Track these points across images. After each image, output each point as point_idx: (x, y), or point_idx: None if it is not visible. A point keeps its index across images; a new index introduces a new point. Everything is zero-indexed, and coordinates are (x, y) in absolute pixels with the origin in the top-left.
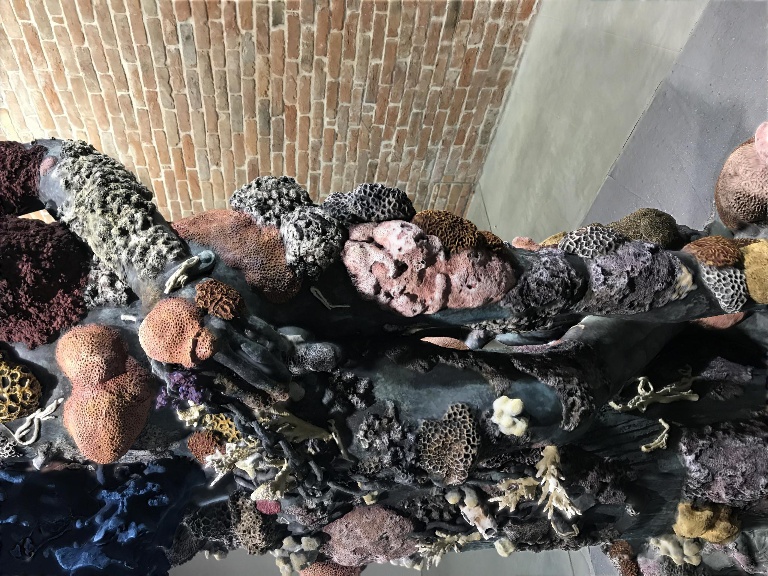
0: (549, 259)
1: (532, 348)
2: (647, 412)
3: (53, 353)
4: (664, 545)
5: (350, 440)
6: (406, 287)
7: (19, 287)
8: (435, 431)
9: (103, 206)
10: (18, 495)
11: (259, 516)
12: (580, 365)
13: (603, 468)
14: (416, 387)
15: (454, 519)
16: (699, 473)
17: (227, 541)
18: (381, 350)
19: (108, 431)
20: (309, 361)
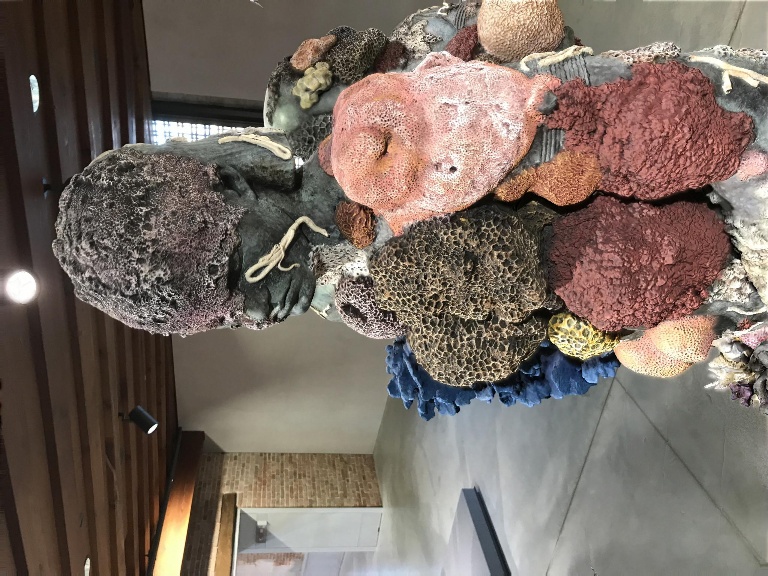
0: None
1: None
2: None
3: None
4: None
5: None
6: None
7: None
8: None
9: None
10: None
11: None
12: None
13: None
14: None
15: None
16: None
17: None
18: None
19: None
20: None
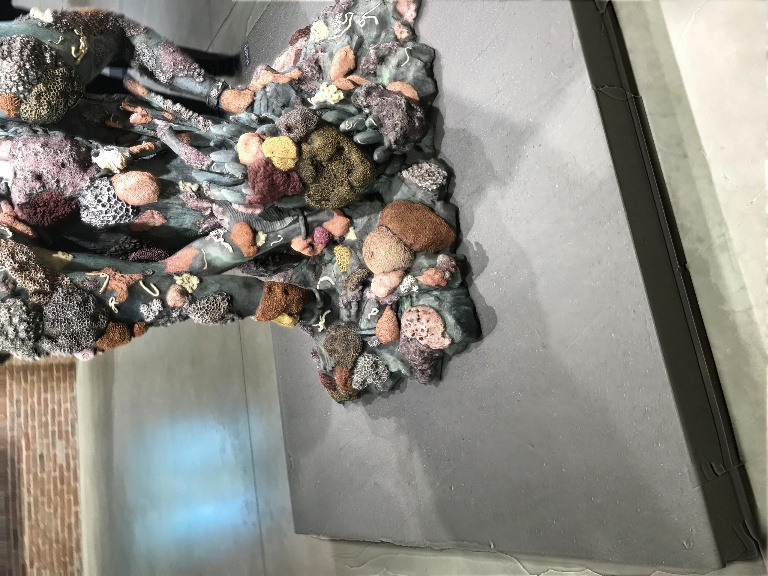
0: None
1: None
2: None
3: None
4: None
5: None
6: None
7: None
8: None
9: None
10: None
11: None
12: None
13: None
14: None
15: None
16: None
17: None
18: None
19: None
20: None
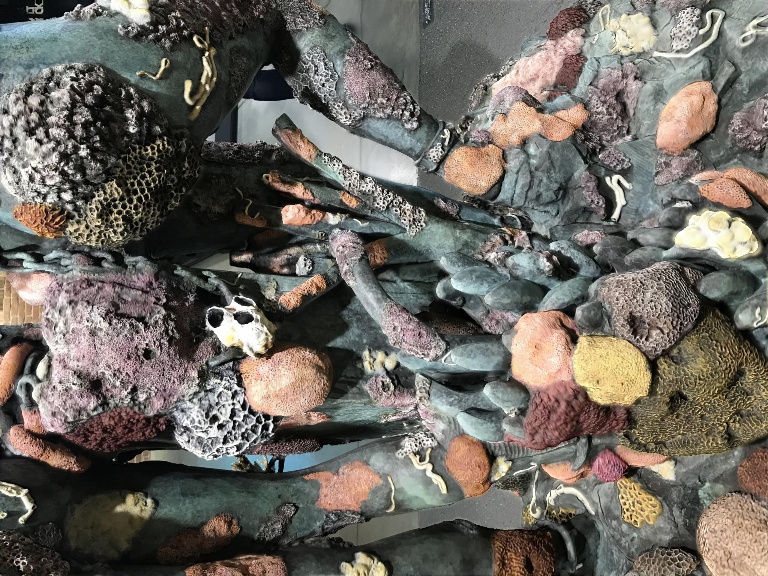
0: None
1: None
2: None
3: None
4: None
5: None
6: None
7: None
8: None
9: None
10: None
11: None
12: None
13: None
14: None
15: None
16: None
17: None
18: None
19: None
20: None
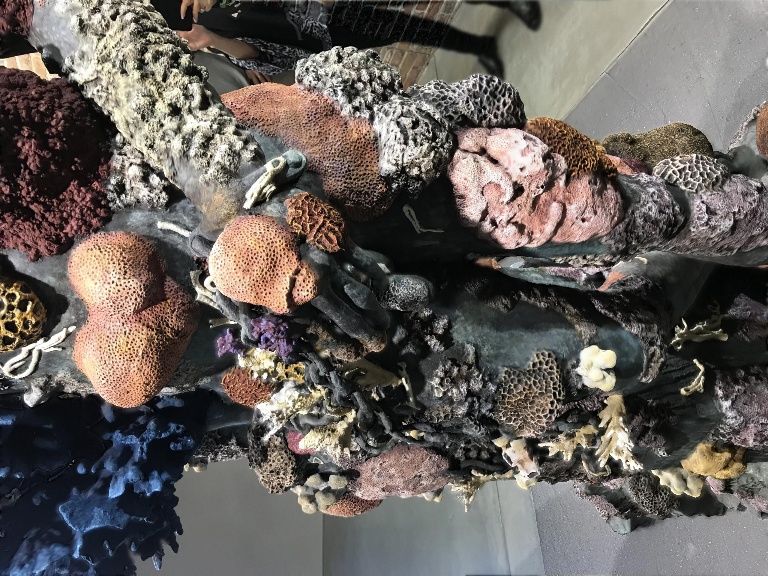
0: (656, 190)
1: (565, 271)
2: (682, 351)
3: (64, 268)
4: (666, 476)
5: (421, 387)
6: (516, 215)
7: (18, 174)
8: (518, 382)
9: (140, 66)
10: (7, 440)
11: (292, 457)
12: (655, 309)
13: (648, 412)
14: (498, 329)
15: (491, 458)
16: (735, 420)
17: (212, 455)
18: (460, 282)
19: (144, 375)
20: (398, 299)
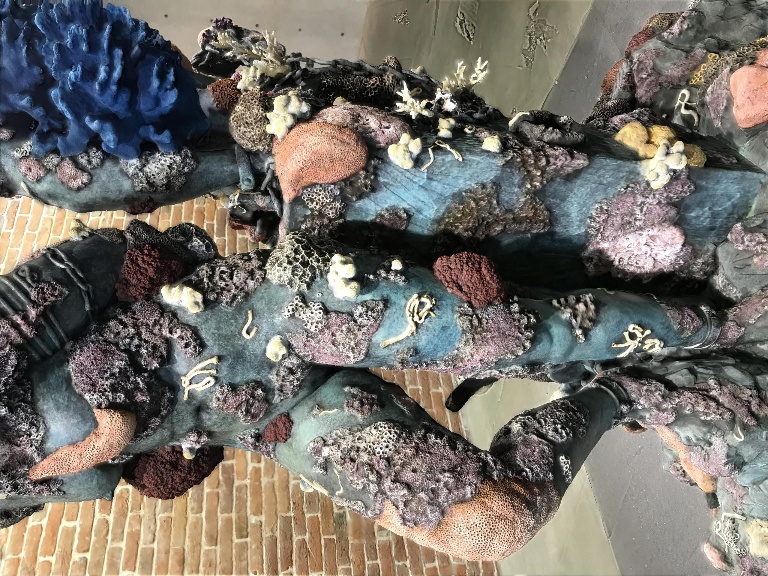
0: None
1: None
2: None
3: None
4: (655, 164)
5: None
6: None
7: None
8: None
9: None
10: None
11: None
12: None
13: None
14: None
15: None
16: None
17: (208, 270)
18: None
19: None
20: None
